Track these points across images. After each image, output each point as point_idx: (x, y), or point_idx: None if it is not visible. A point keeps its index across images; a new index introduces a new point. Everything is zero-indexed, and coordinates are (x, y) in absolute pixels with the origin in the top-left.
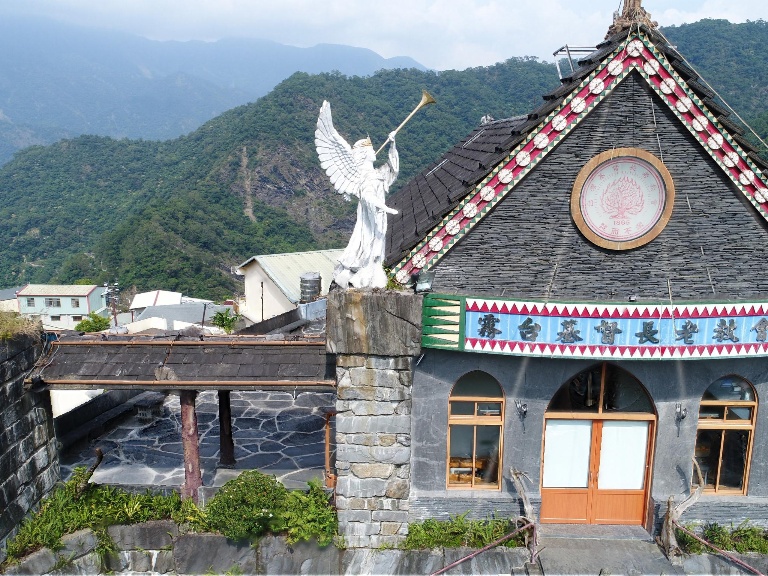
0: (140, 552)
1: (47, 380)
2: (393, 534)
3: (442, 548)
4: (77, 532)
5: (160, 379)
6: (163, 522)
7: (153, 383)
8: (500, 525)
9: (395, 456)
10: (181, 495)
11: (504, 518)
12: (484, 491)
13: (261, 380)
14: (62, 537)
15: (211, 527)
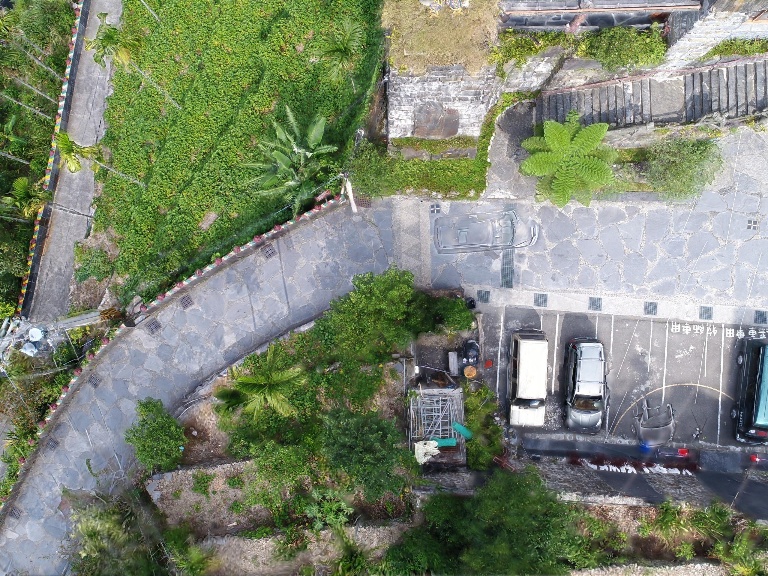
0: (539, 59)
1: (508, 12)
2: (696, 55)
3: (720, 55)
4: (510, 61)
5: (583, 8)
6: (556, 48)
7: (579, 12)
8: (760, 43)
9: (720, 36)
10: (565, 30)
11: (764, 37)
12: (759, 24)
13: (649, 3)
14: (504, 67)
15: (588, 54)
